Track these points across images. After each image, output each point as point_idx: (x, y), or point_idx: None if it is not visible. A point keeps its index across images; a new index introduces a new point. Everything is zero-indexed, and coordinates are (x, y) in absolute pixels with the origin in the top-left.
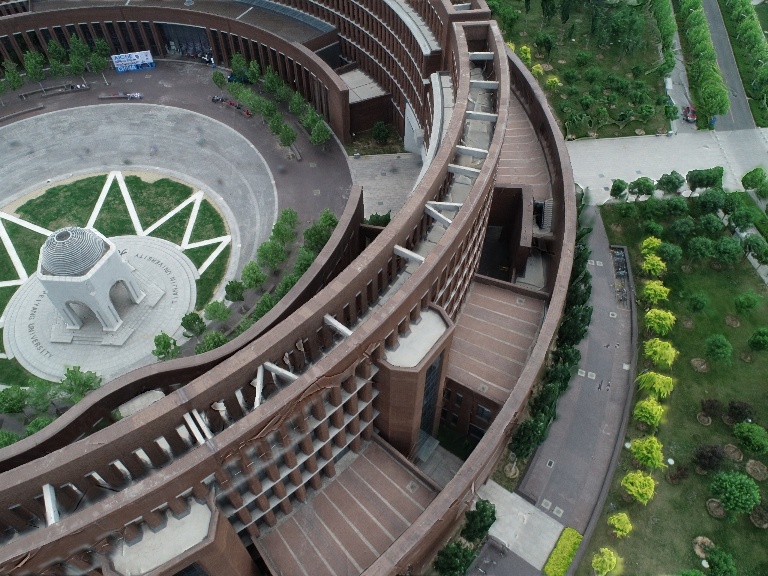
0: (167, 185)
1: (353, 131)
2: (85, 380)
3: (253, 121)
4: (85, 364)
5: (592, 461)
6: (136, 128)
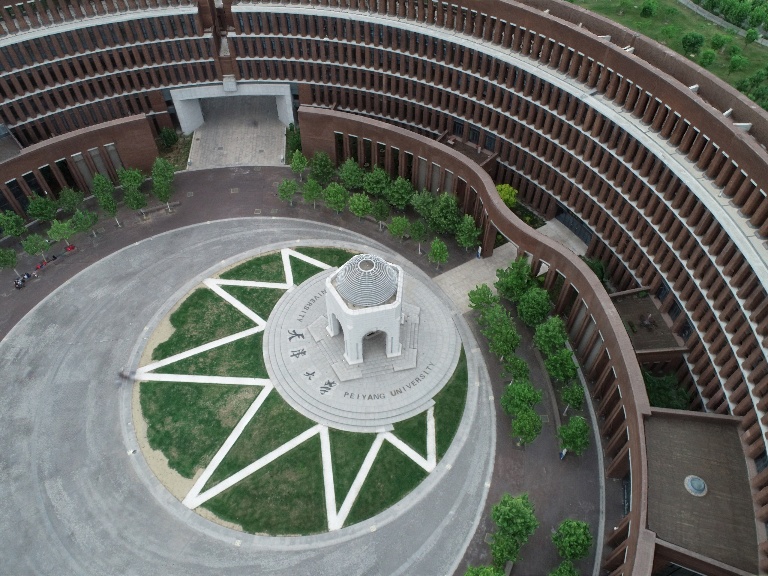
0: (184, 313)
1: None
2: None
3: (86, 246)
4: (440, 333)
5: None
6: (43, 368)
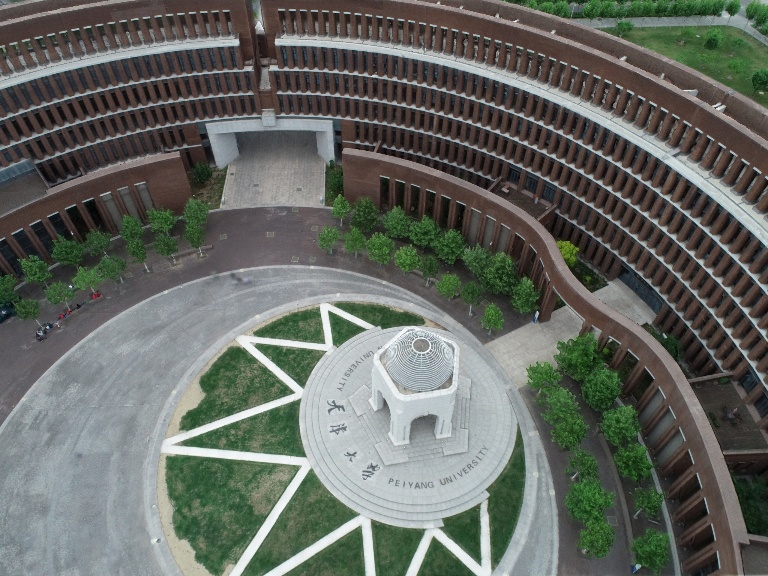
0: (215, 376)
1: None
2: None
3: (112, 293)
4: (494, 411)
5: None
6: (63, 435)
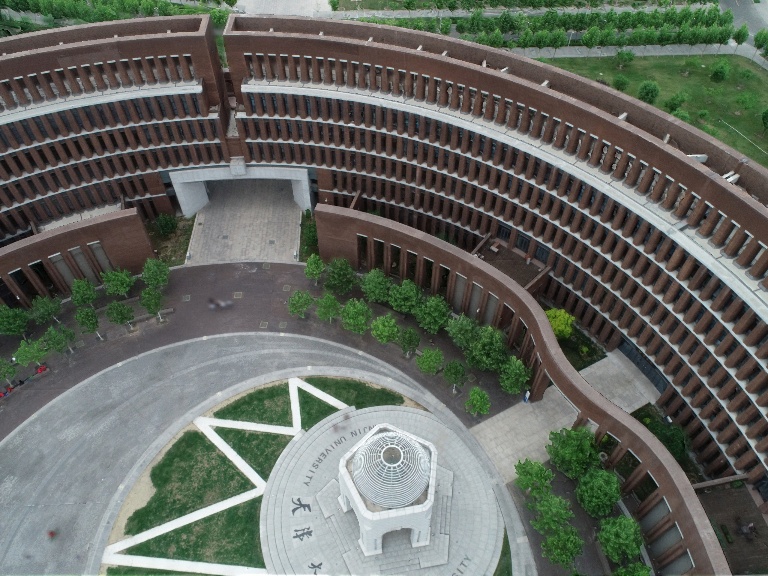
0: (168, 467)
1: None
2: None
3: (61, 366)
4: (478, 511)
5: None
6: None
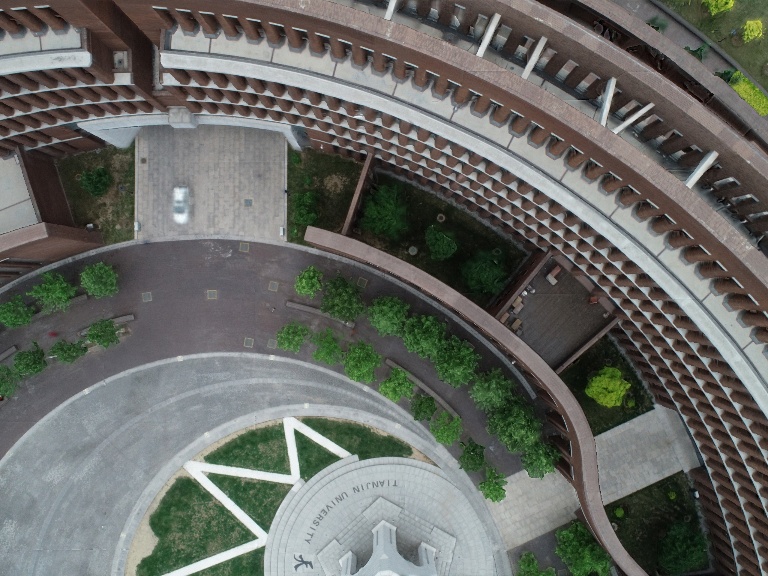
0: (166, 516)
1: (73, 226)
2: (535, 572)
3: (18, 391)
4: None
5: (665, 35)
6: None
